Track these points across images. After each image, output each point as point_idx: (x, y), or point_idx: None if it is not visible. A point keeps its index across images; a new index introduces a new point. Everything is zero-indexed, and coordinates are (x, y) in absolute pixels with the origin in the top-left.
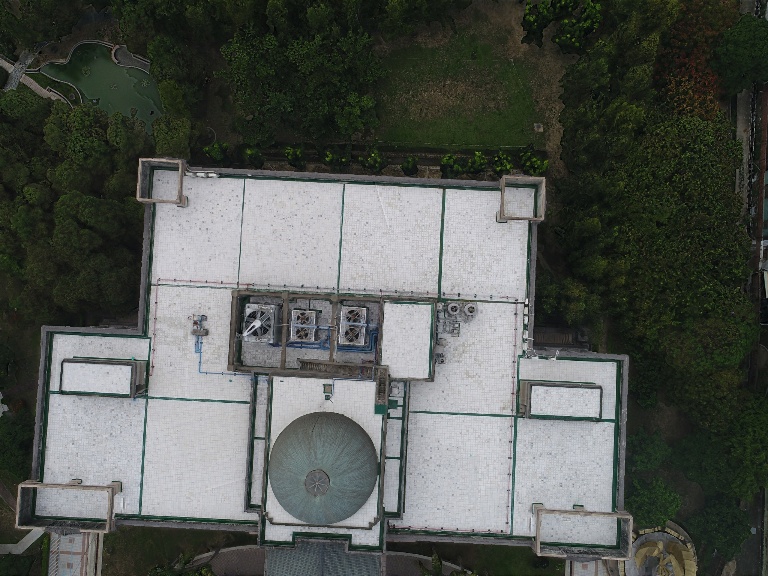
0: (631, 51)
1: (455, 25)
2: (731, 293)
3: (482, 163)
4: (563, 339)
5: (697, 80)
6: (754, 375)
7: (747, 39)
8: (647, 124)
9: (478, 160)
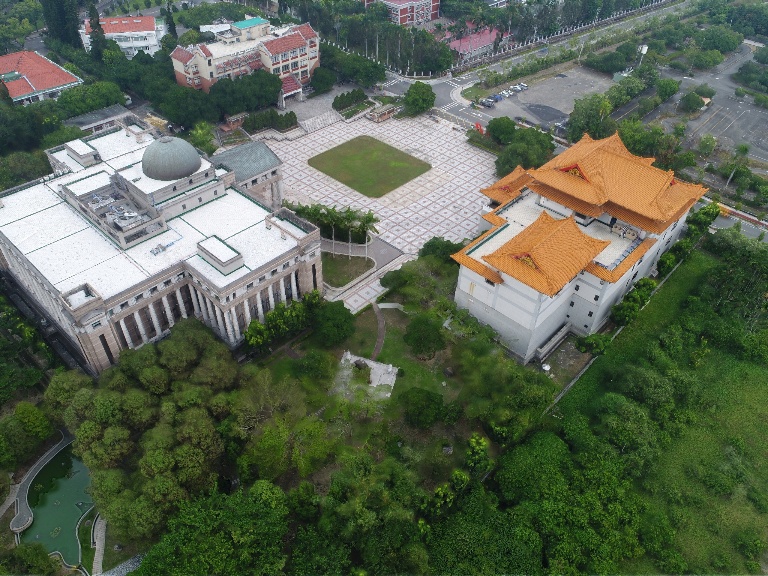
0: None
1: None
2: None
3: None
4: None
5: None
6: None
7: None
8: None
9: None
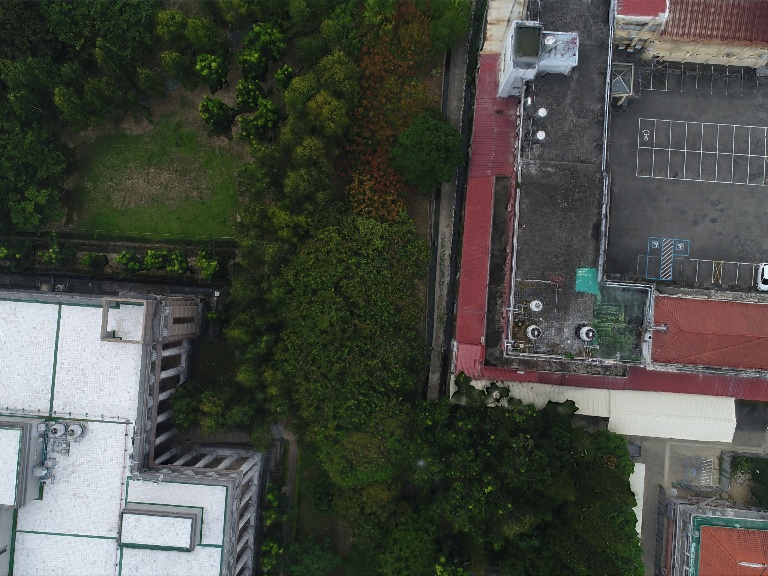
0: (294, 154)
1: (161, 111)
2: (387, 405)
3: (154, 262)
4: None
5: (378, 180)
6: None
7: (415, 143)
8: (310, 229)
9: (149, 260)
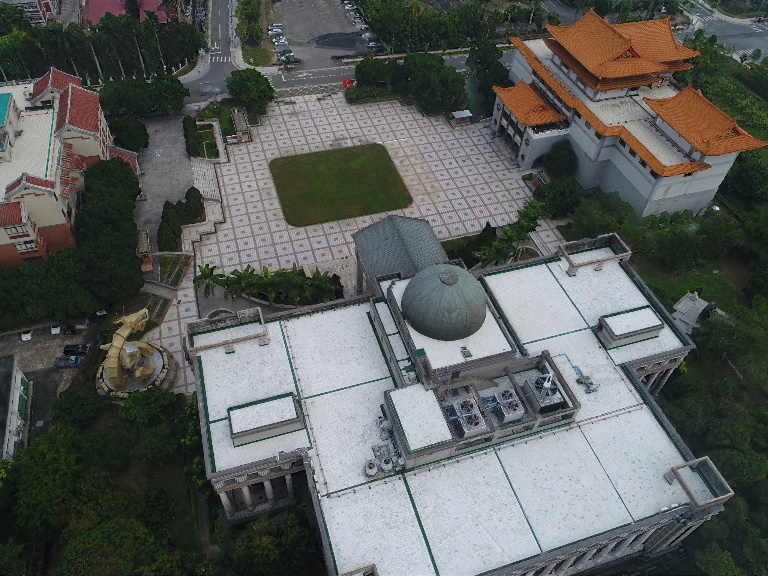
0: None
1: None
2: None
3: None
4: None
5: None
6: (33, 567)
7: None
8: None
9: None
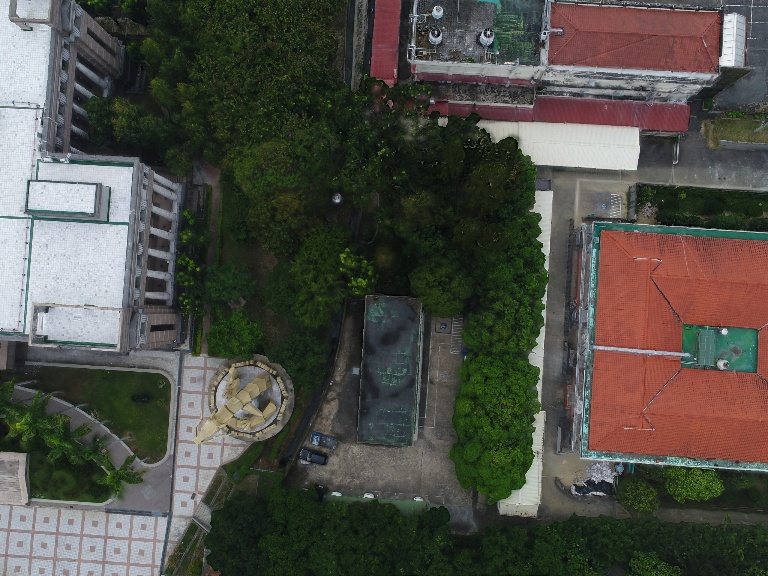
0: None
1: None
2: (298, 120)
3: None
4: (174, 181)
5: None
6: None
7: None
8: None
9: None
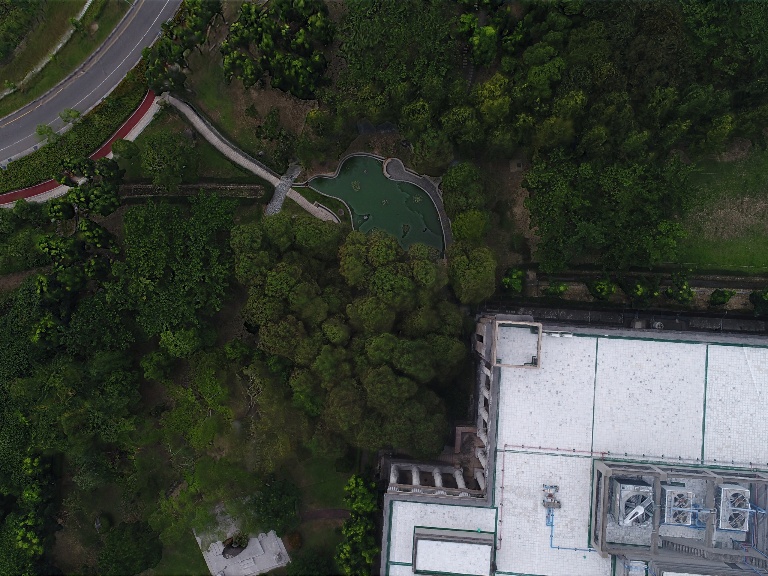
0: None
1: None
2: None
3: None
4: None
5: None
6: None
7: None
8: None
9: None
